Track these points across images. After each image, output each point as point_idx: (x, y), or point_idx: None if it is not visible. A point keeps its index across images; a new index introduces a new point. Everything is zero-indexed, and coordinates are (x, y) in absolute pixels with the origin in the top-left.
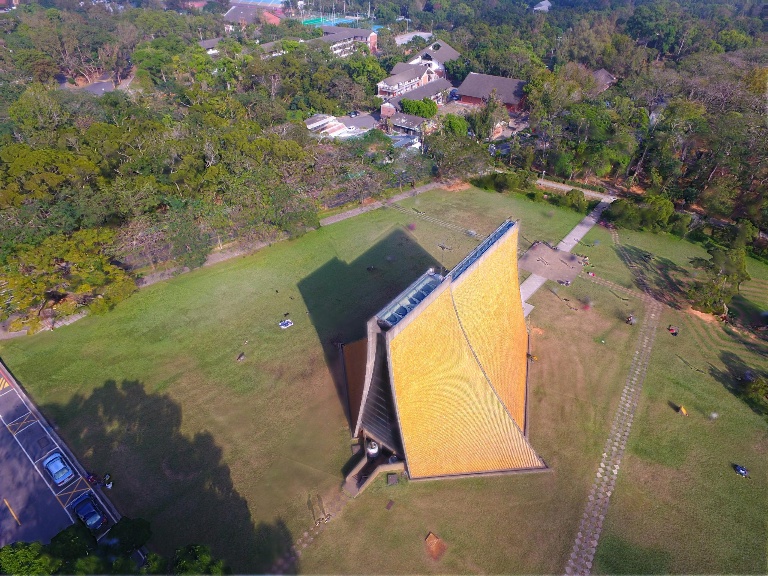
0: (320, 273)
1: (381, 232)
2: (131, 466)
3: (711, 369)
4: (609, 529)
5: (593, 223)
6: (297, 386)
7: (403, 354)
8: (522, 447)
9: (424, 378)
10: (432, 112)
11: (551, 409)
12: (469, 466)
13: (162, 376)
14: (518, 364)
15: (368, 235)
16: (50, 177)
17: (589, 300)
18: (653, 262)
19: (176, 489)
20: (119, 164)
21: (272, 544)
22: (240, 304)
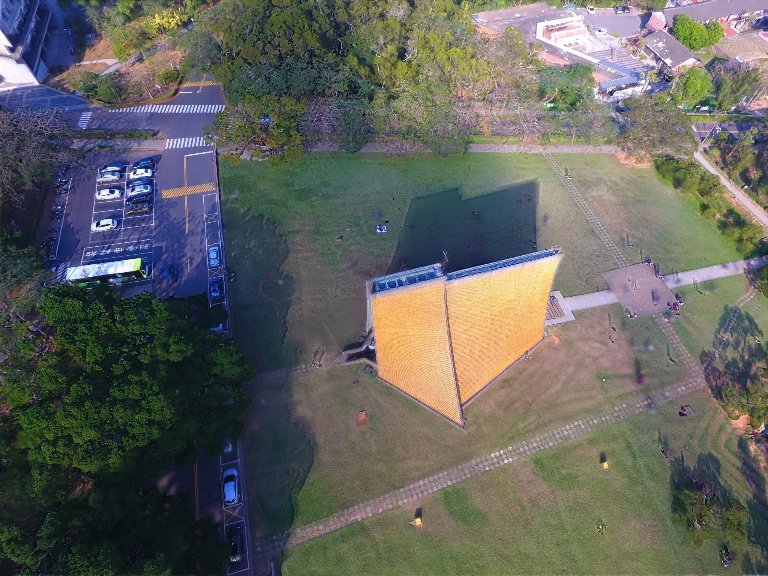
0: (435, 198)
1: (514, 181)
2: (246, 275)
3: (677, 458)
4: (466, 484)
5: (740, 271)
6: (358, 279)
7: (385, 309)
8: (453, 405)
9: (400, 328)
10: (709, 42)
11: (504, 397)
12: (415, 393)
13: (289, 227)
14: (505, 354)
15: (501, 179)
16: (283, 44)
17: (636, 341)
18: (753, 345)
19: (259, 301)
20: (347, 29)
21: (285, 360)
22: (363, 197)
